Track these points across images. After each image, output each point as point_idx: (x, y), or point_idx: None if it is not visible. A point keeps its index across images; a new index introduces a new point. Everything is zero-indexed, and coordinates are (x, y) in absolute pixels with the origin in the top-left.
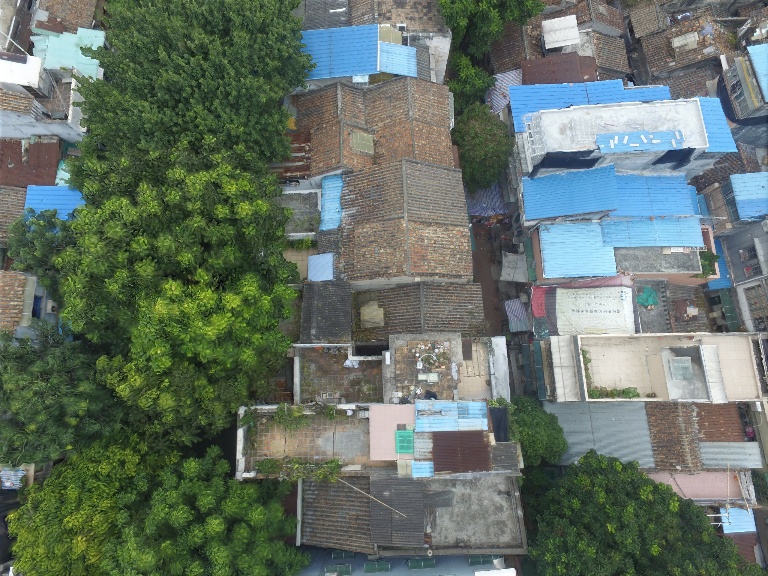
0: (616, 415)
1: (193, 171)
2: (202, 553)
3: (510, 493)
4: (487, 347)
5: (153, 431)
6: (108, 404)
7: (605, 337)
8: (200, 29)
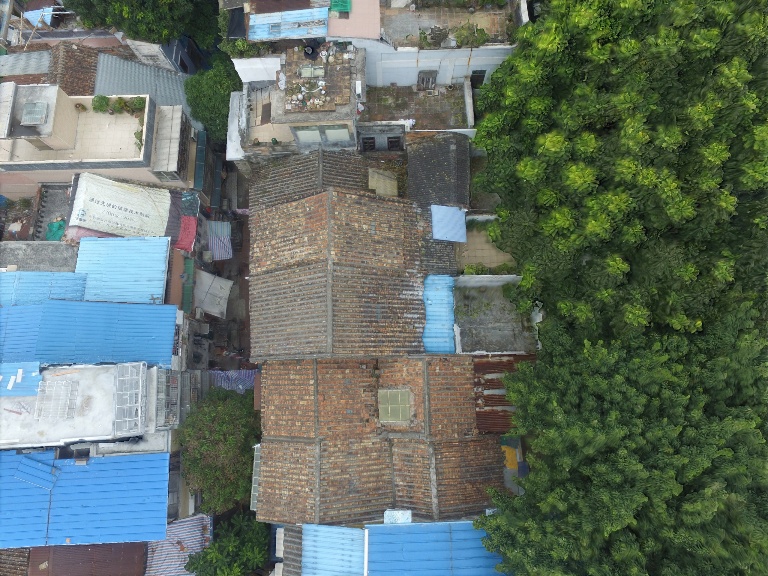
0: None
1: (652, 248)
2: None
3: None
4: (247, 140)
5: None
6: None
7: None
8: (709, 567)
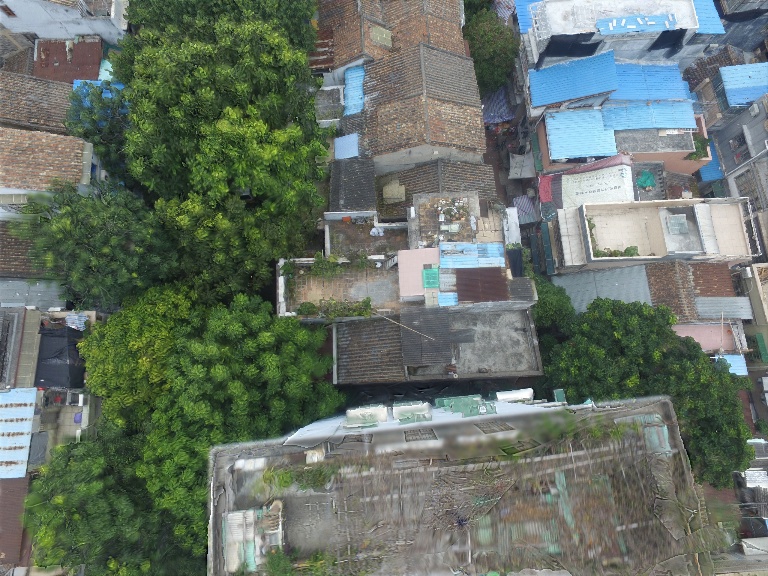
0: (619, 280)
1: None
2: (256, 363)
3: (526, 329)
4: None
5: (201, 283)
6: (164, 246)
7: (608, 207)
8: None
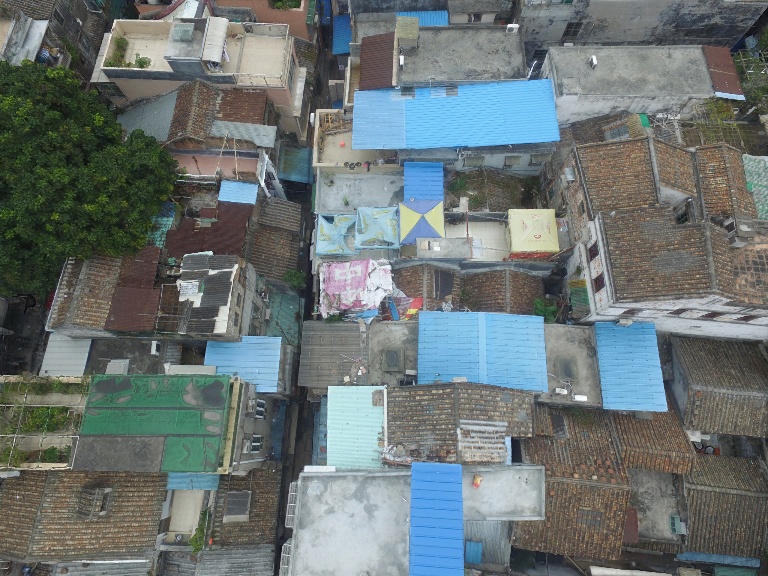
0: (158, 108)
1: None
2: None
3: None
4: None
5: None
6: None
7: (148, 29)
8: None
